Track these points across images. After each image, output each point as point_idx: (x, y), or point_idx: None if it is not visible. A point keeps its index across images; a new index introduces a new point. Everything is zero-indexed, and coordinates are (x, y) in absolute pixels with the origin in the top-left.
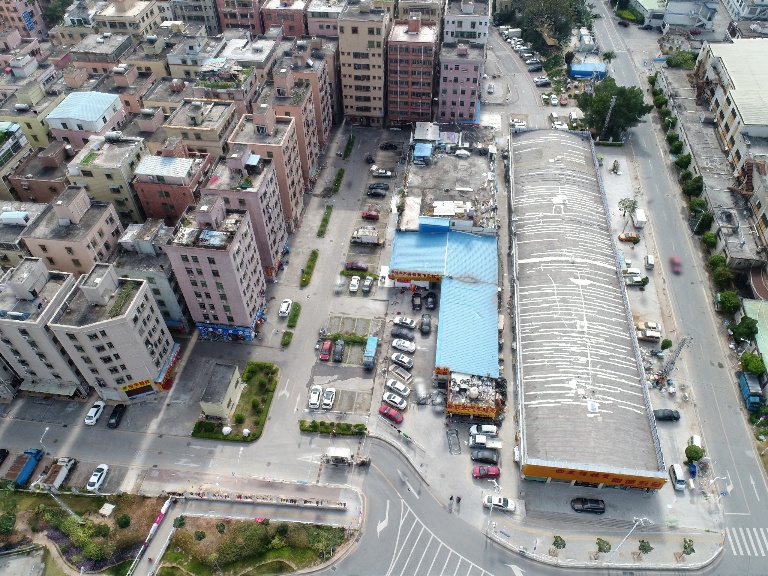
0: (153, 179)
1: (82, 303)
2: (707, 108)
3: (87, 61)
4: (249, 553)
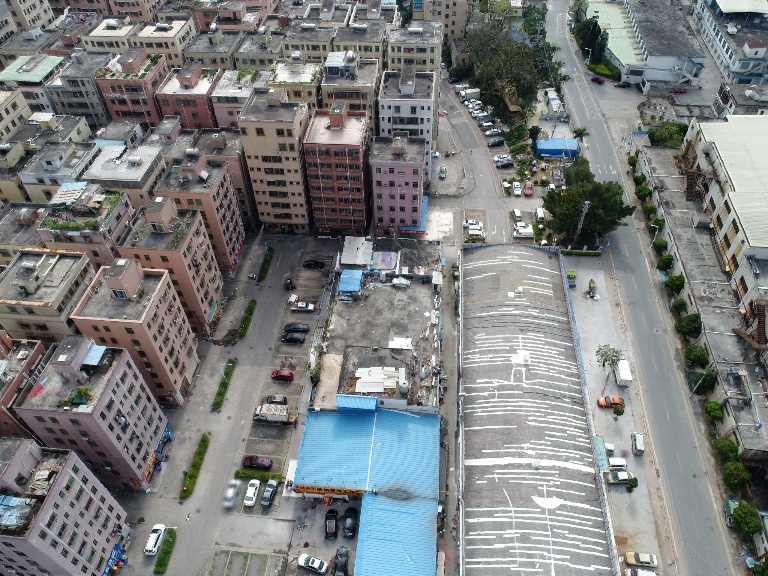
0: None
1: None
2: (700, 205)
3: None
4: None
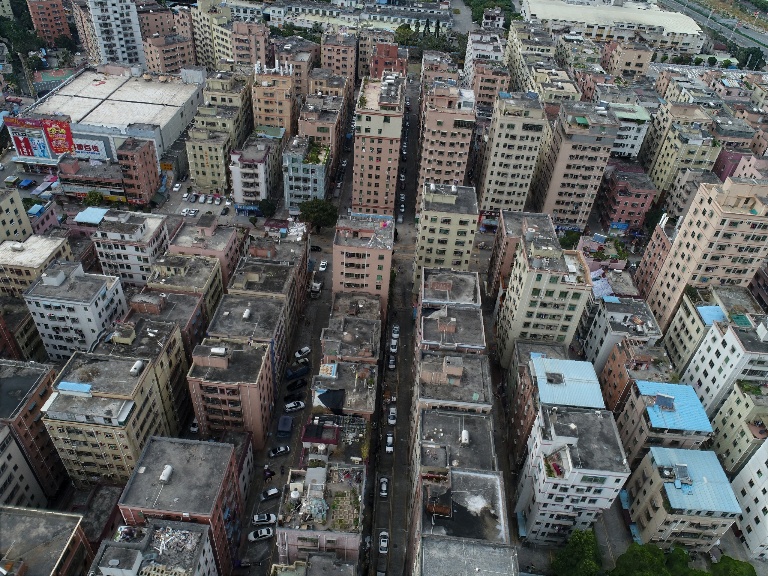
0: None
1: None
2: None
3: None
4: None
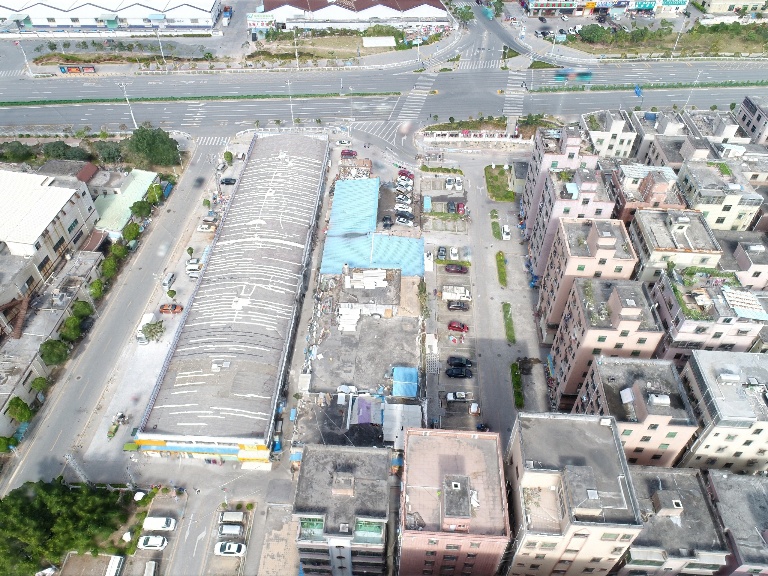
0: None
1: None
2: None
3: None
4: (466, 122)
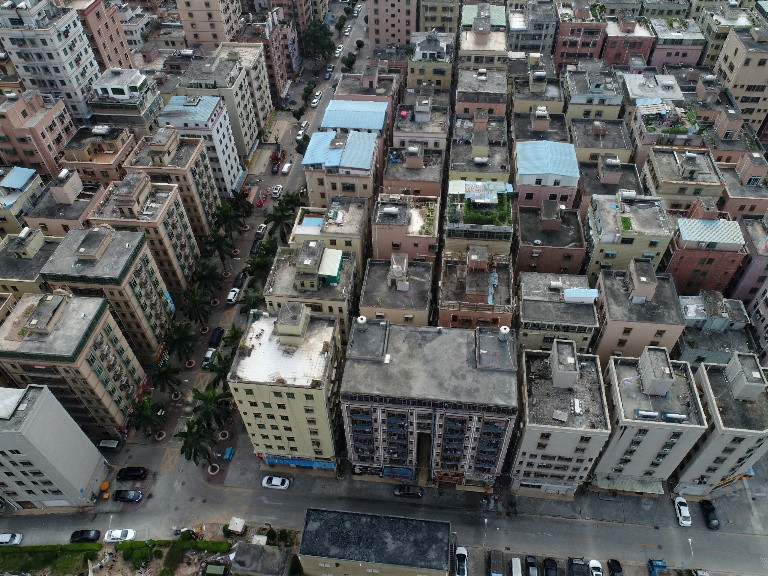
0: (703, 246)
1: (726, 399)
2: None
3: (475, 101)
4: None
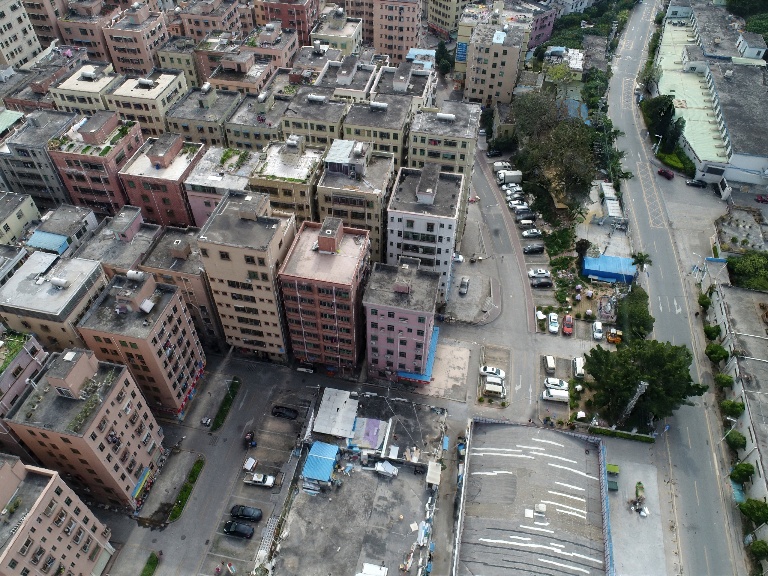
0: None
1: None
2: None
3: None
4: None
